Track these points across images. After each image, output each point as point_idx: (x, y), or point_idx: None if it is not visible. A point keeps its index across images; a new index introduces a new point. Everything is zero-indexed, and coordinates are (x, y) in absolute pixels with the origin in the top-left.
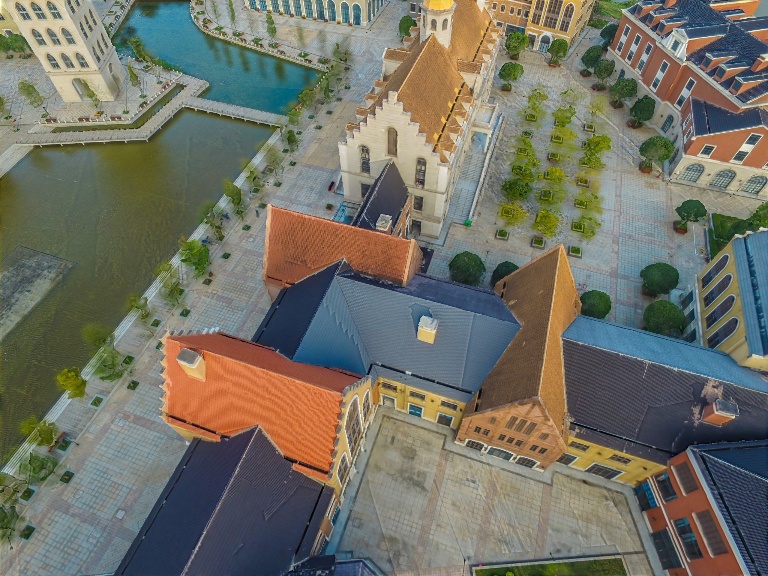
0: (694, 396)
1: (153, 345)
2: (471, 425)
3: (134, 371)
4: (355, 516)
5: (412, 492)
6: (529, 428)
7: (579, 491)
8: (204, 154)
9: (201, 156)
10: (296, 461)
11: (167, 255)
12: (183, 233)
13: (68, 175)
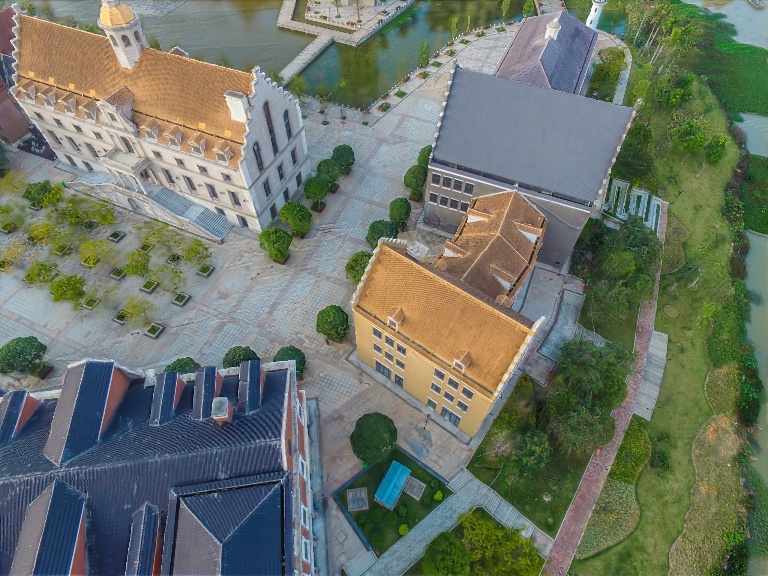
0: None
1: None
2: None
3: None
4: None
5: None
6: None
7: None
8: (250, 52)
9: (248, 51)
10: None
11: None
12: None
13: (251, 5)
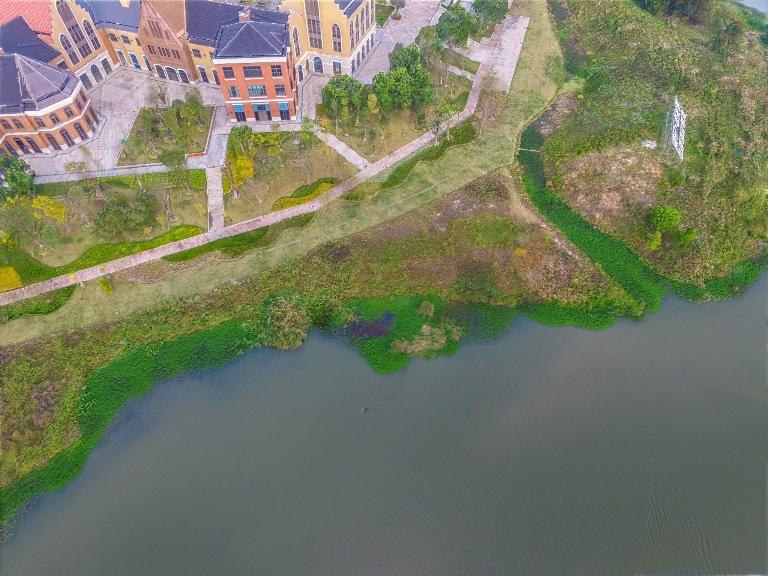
0: None
1: None
2: (145, 45)
3: None
4: (90, 96)
5: (123, 90)
6: (159, 30)
7: (210, 90)
8: None
9: None
10: (39, 33)
11: None
12: None
13: None
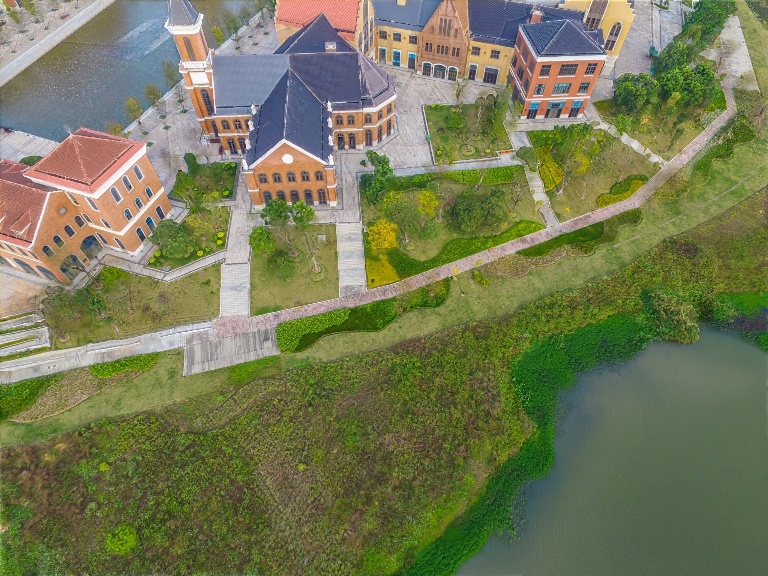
0: (527, 14)
1: (250, 44)
2: (423, 43)
3: (242, 51)
4: None
5: None
6: (449, 28)
7: (479, 88)
8: None
9: None
10: (340, 31)
11: (250, 15)
12: (258, 7)
13: None
